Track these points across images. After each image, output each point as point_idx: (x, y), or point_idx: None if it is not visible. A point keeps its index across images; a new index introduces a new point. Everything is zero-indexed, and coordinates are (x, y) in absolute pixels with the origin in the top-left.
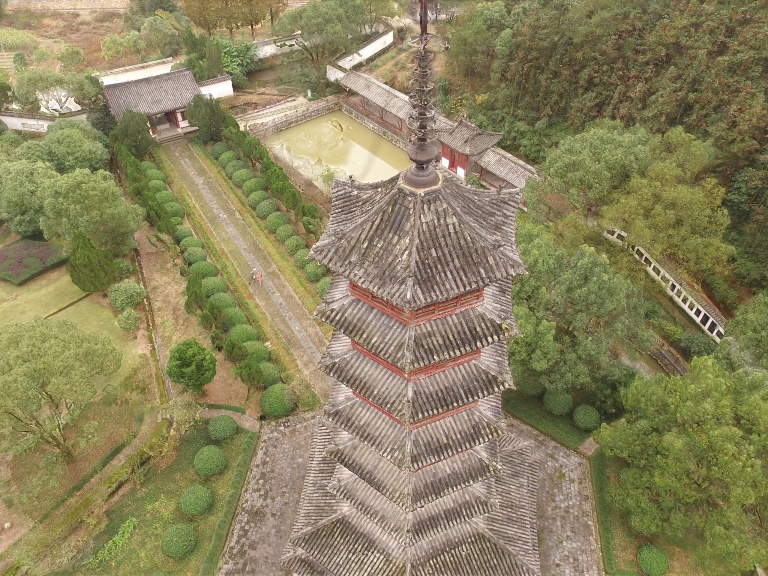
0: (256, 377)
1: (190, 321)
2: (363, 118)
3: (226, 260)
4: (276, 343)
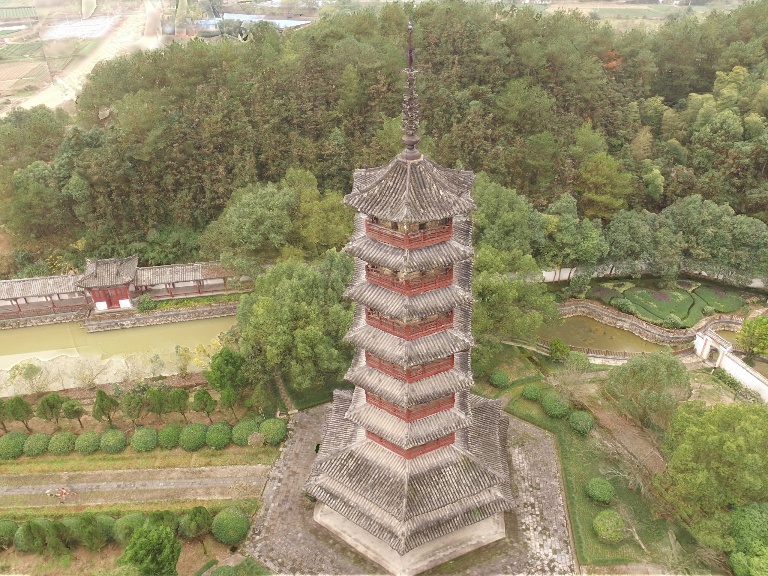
0: (209, 516)
1: (52, 575)
2: None
3: (3, 512)
4: (162, 507)
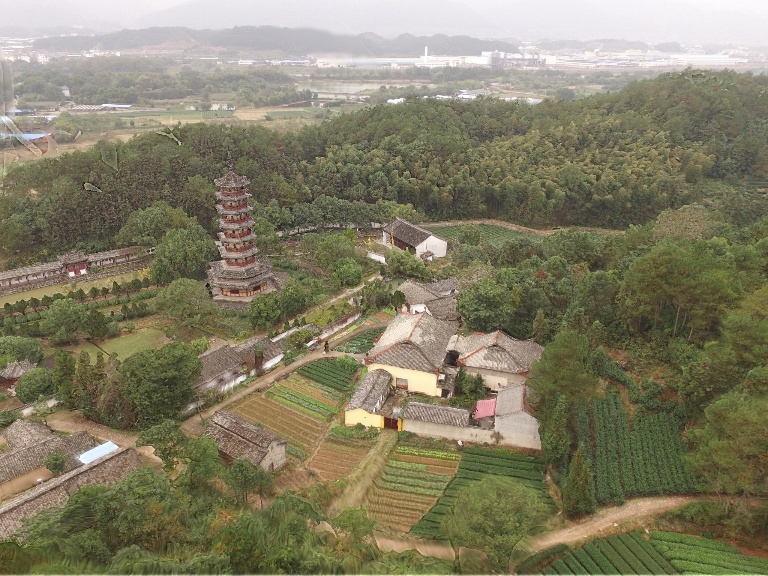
0: None
1: (134, 323)
2: (2, 292)
3: None
4: None
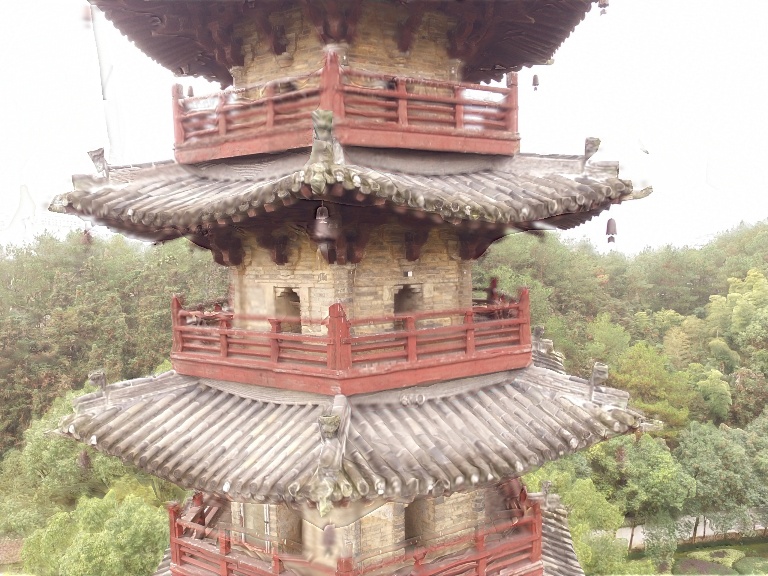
0: None
1: None
2: None
3: None
4: None
